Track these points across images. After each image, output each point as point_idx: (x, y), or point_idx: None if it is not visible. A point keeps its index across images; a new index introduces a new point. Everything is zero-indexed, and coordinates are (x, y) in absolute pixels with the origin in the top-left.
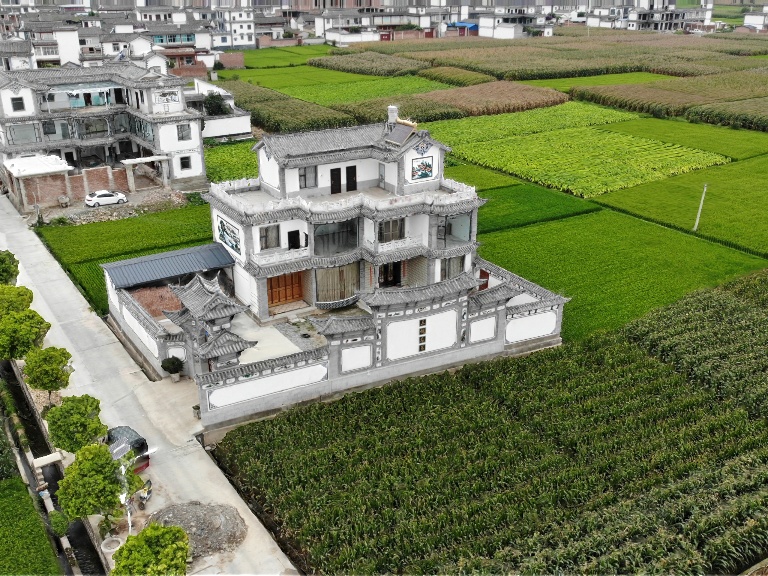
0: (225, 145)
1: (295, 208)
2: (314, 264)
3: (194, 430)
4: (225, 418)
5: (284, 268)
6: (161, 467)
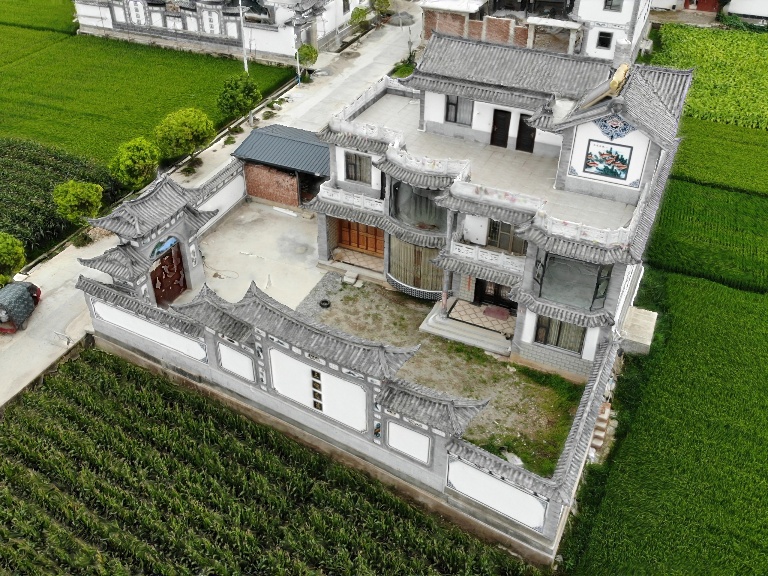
0: (747, 30)
1: (393, 144)
2: (379, 225)
3: (89, 327)
4: (111, 334)
5: (343, 213)
6: (26, 340)
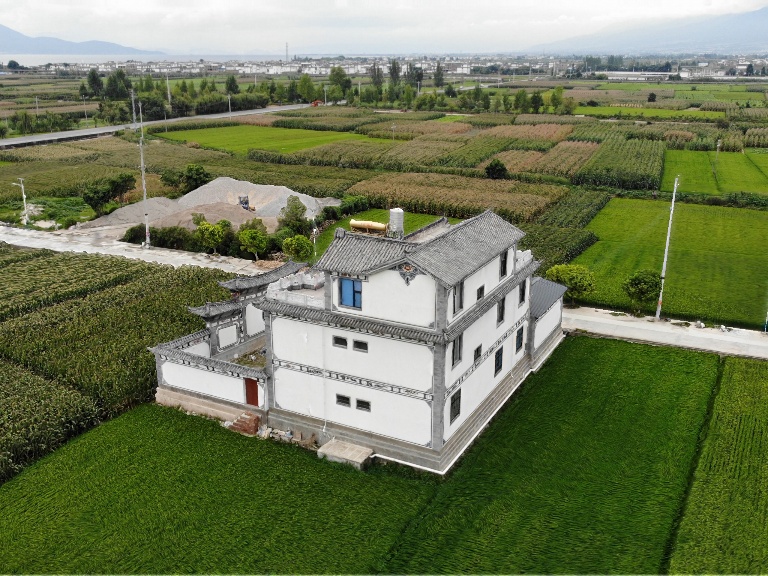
0: None
1: None
2: None
3: None
4: None
5: None
6: None
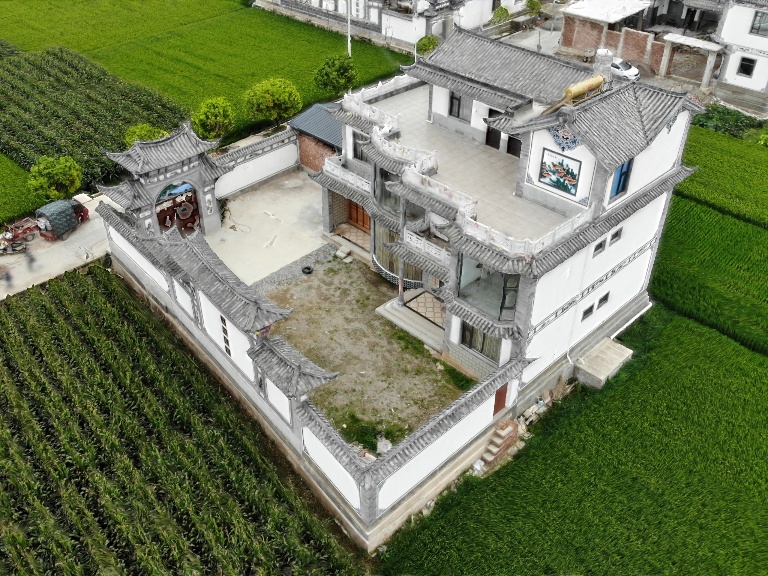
0: None
1: None
2: (363, 205)
3: None
4: None
5: (338, 188)
6: (60, 249)
